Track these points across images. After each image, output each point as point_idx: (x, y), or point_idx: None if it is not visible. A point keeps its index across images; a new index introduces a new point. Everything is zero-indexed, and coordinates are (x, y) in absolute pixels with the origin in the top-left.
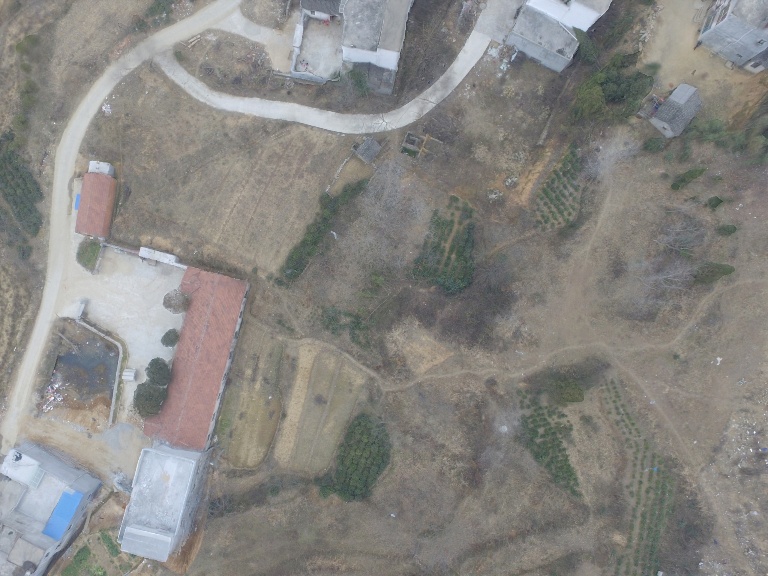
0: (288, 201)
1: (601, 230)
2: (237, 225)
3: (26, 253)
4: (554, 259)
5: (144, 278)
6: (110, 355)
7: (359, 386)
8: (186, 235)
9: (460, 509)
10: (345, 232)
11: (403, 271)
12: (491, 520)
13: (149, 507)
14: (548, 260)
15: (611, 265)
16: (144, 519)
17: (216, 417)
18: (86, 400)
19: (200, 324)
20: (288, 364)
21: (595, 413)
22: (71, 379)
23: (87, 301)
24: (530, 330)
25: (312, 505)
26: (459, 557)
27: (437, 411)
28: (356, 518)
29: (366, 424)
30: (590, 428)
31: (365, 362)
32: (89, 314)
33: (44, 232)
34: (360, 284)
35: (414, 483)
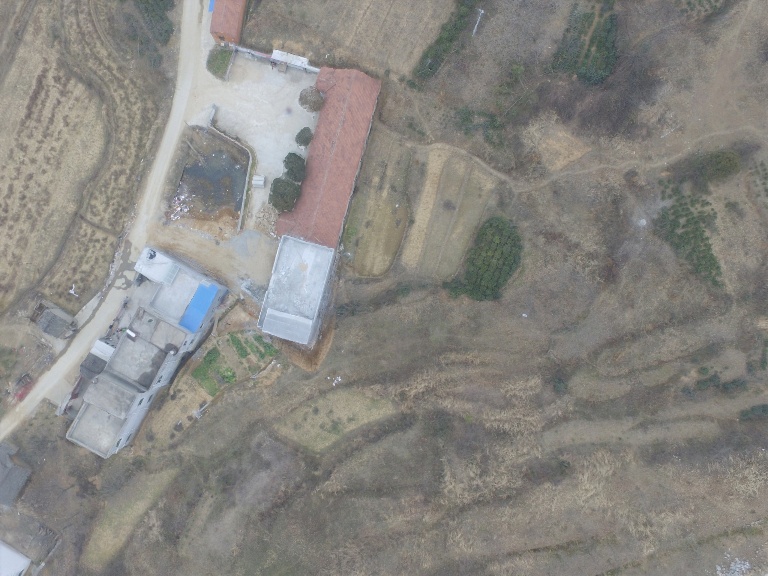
0: (423, 1)
1: (751, 14)
2: (370, 27)
3: (157, 60)
4: (702, 44)
5: (273, 85)
6: (235, 167)
7: (489, 191)
8: (318, 39)
9: (596, 304)
10: (481, 30)
11: (541, 66)
12: (628, 315)
13: (287, 295)
14: (695, 46)
15: (762, 48)
16: (282, 307)
17: (343, 224)
18: (211, 212)
19: (336, 119)
20: (417, 169)
21: (742, 199)
22: (197, 191)
23: (217, 108)
24: (675, 117)
25: (444, 303)
26: (595, 351)
27: (572, 209)
28: (488, 316)
29: (498, 224)
30: (736, 215)
31: (496, 166)
32: (218, 121)
33: (175, 40)
34: (496, 82)
35: (545, 284)
